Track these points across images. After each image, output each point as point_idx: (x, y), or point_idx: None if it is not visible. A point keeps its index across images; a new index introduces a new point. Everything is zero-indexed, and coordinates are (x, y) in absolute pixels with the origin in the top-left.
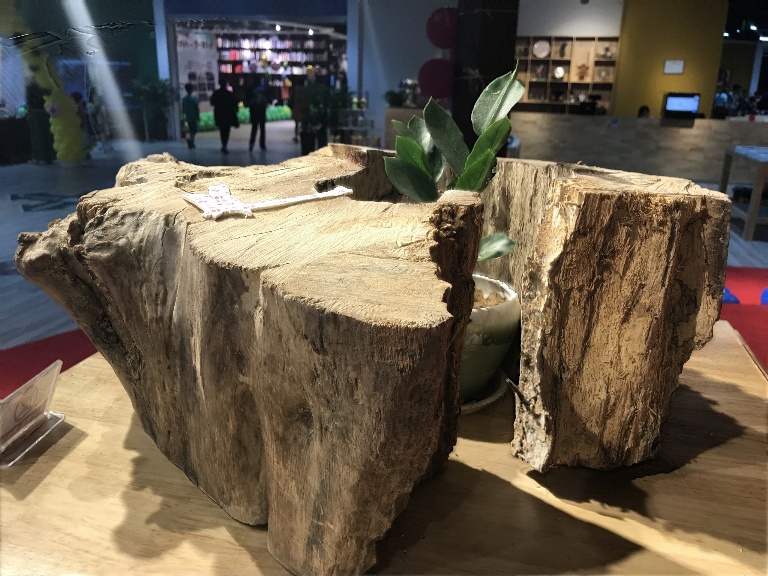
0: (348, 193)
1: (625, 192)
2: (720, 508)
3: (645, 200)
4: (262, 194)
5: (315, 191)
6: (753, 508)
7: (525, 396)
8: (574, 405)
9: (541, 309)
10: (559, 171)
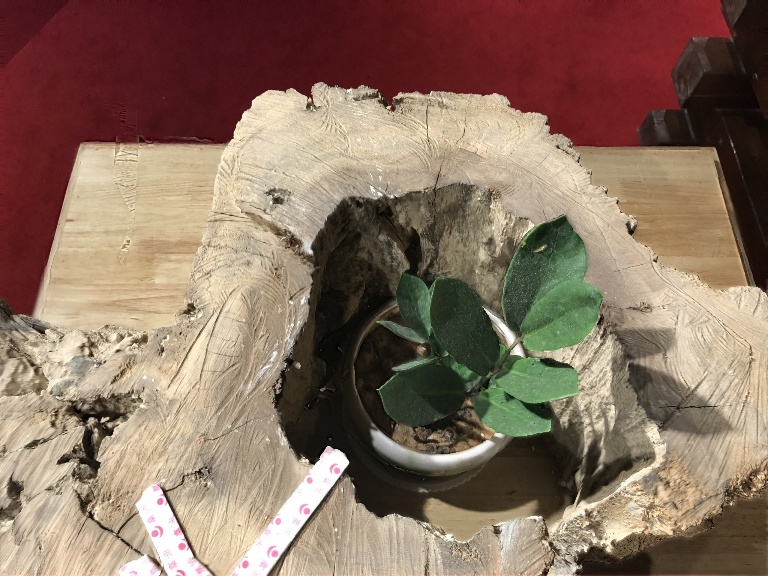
0: None
1: (727, 488)
2: (710, 562)
3: (746, 480)
4: (222, 500)
5: (289, 452)
6: (736, 553)
7: (555, 545)
8: (604, 550)
9: (593, 541)
10: (630, 388)
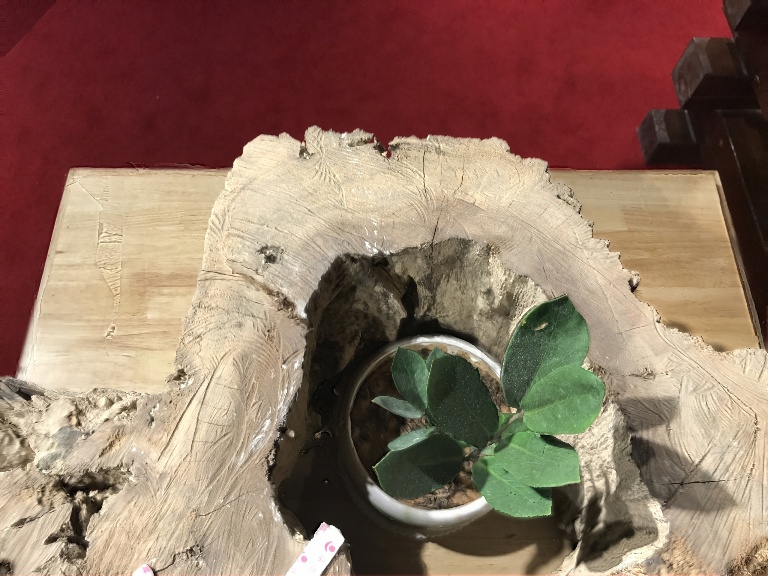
0: (339, 547)
1: (731, 569)
2: None
3: None
4: None
5: (283, 528)
6: None
7: None
8: None
9: None
10: (632, 463)
